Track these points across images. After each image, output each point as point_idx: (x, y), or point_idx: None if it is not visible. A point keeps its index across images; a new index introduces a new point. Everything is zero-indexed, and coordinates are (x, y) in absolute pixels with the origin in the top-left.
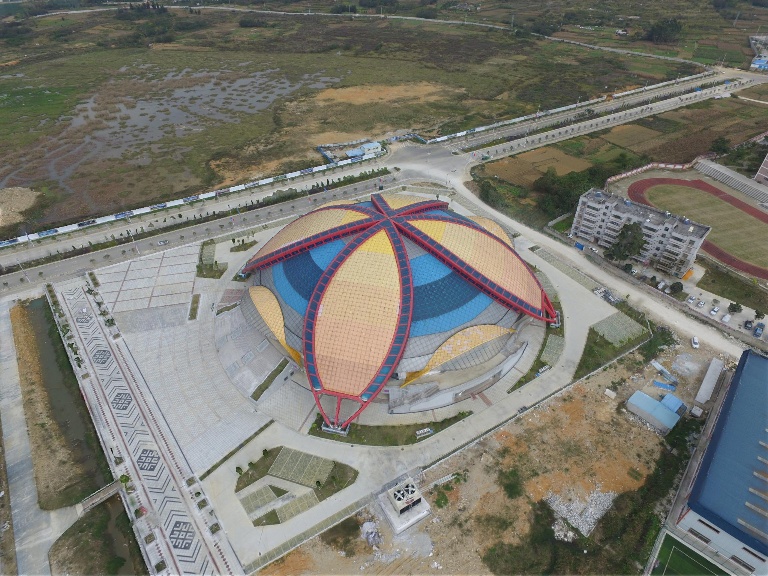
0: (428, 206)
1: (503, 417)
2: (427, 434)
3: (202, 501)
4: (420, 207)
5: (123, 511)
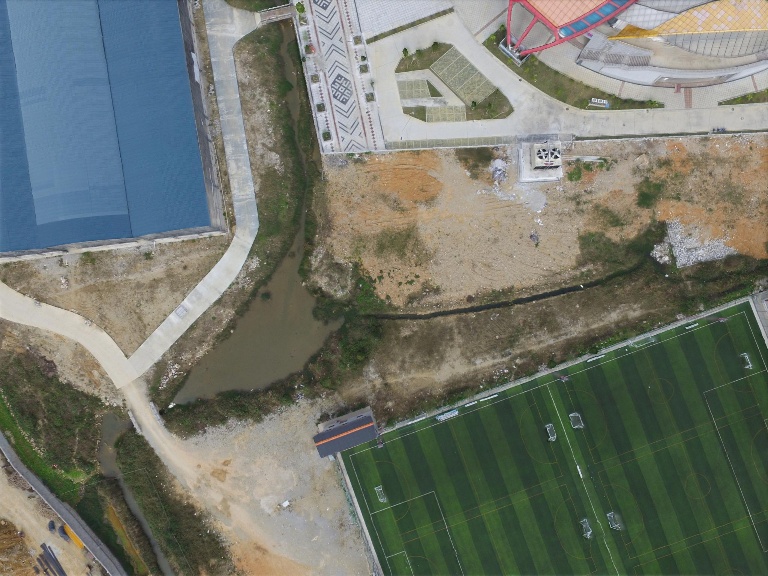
0: None
1: (692, 128)
2: (601, 106)
3: (364, 66)
4: None
5: (294, 39)
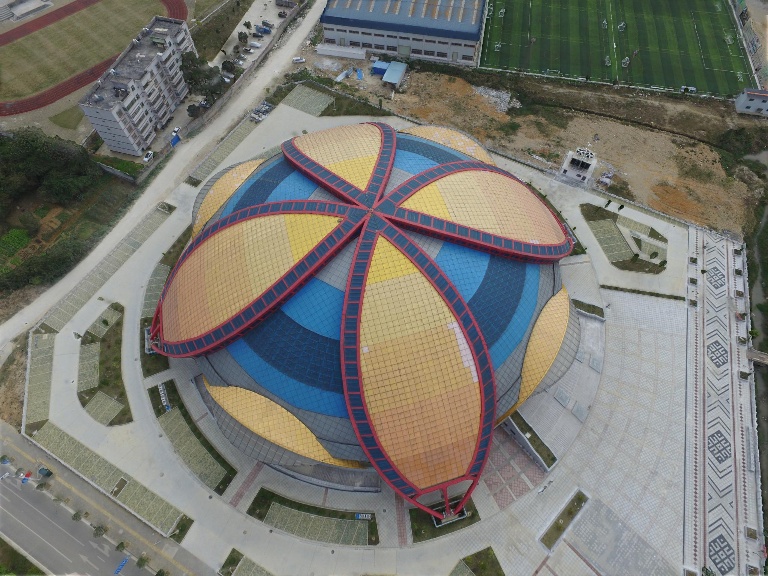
0: None
1: None
2: None
3: (693, 282)
4: (307, 200)
5: None
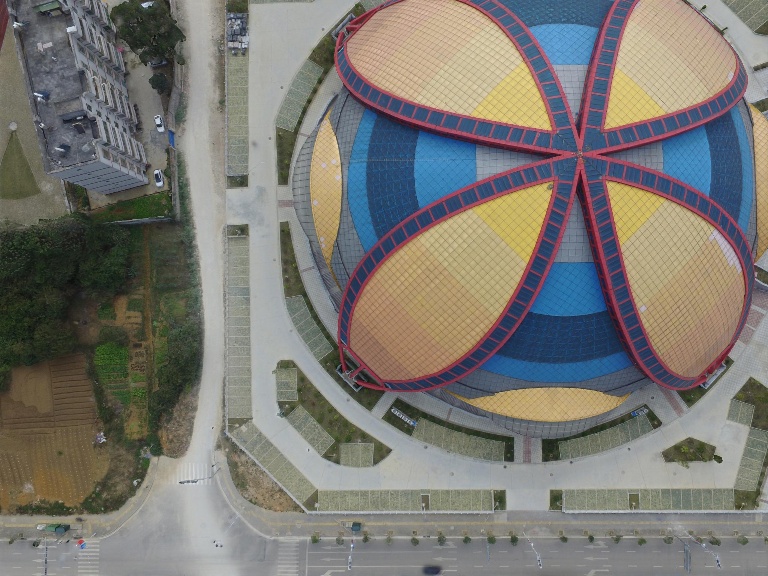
0: (462, 190)
1: None
2: None
3: None
4: (490, 178)
5: None
